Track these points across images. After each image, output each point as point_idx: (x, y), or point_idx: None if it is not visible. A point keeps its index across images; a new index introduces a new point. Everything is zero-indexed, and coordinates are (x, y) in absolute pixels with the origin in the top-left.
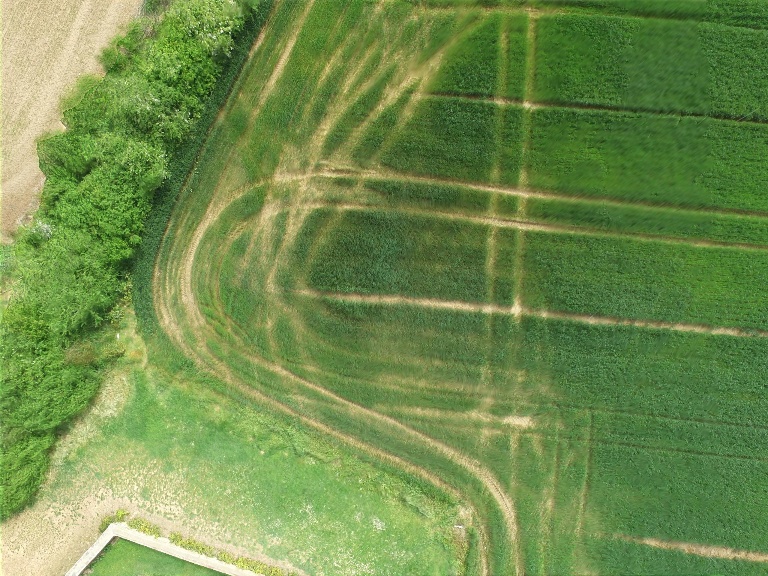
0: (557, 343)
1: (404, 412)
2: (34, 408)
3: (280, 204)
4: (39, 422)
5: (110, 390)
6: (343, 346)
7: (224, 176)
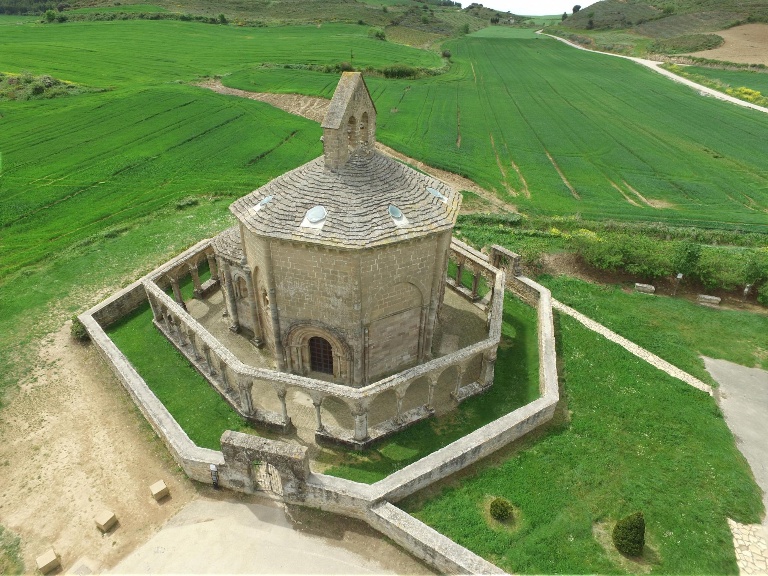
0: (131, 175)
1: (125, 206)
2: None
3: None
4: None
5: None
6: (58, 220)
7: None
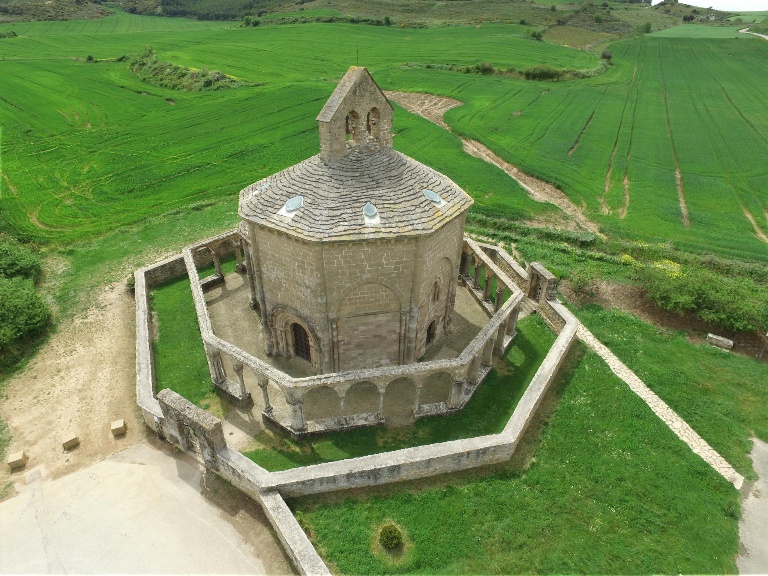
0: None
1: None
2: (1, 252)
3: (71, 196)
4: (13, 258)
5: (50, 265)
6: (166, 191)
7: (24, 207)
